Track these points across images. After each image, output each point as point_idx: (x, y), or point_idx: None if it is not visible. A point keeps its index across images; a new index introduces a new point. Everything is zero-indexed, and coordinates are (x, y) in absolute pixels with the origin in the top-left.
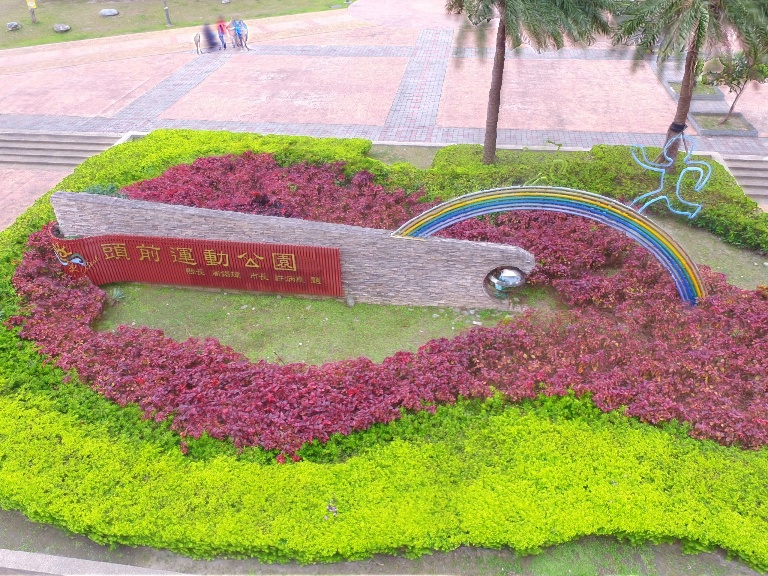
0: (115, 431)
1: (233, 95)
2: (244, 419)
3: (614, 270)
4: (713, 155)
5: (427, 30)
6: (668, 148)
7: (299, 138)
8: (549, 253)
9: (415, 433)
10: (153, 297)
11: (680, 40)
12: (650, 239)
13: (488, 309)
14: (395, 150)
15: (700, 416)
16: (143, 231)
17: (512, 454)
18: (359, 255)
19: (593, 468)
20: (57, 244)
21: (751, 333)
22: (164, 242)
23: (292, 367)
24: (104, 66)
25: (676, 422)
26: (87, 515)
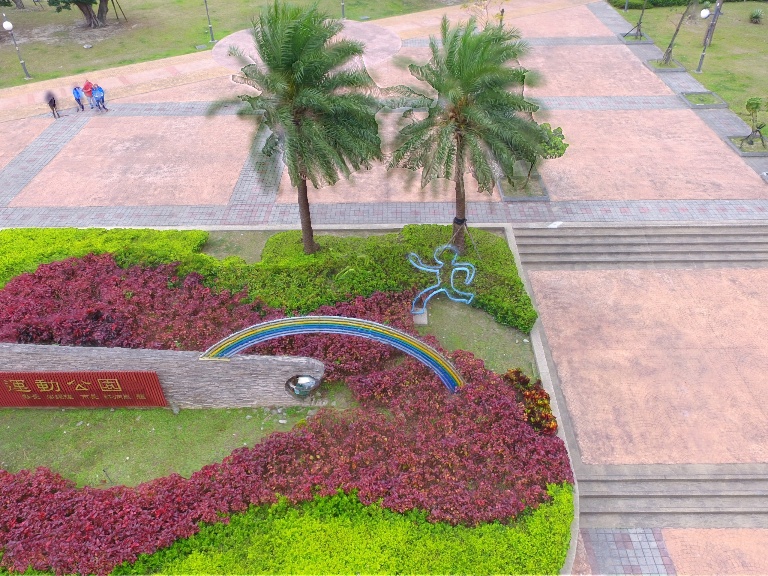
0: None
1: (86, 172)
2: (64, 550)
3: (402, 358)
4: (506, 227)
5: None
6: (455, 237)
7: (141, 232)
8: (345, 351)
9: (211, 544)
10: None
11: (433, 172)
12: (410, 348)
13: (294, 406)
14: (233, 236)
15: (437, 502)
16: None
17: (284, 556)
18: (175, 374)
19: (345, 562)
20: None
21: (492, 417)
22: None
23: (112, 491)
24: None
25: (417, 511)
26: None
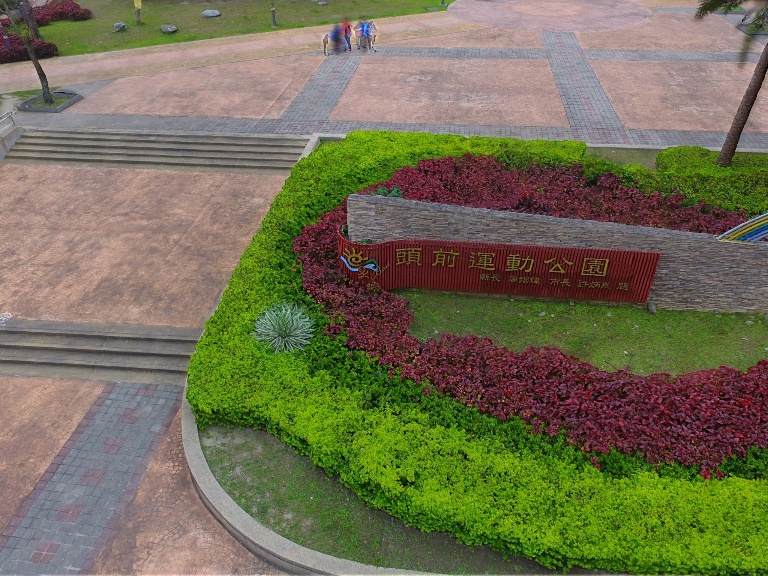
0: (512, 446)
1: (392, 97)
2: (649, 433)
3: None
4: None
5: (546, 32)
6: None
7: (507, 140)
8: None
9: None
10: (437, 304)
11: None
12: None
13: None
14: (604, 152)
15: None
16: (441, 235)
17: None
18: (677, 260)
19: None
20: (353, 249)
21: None
22: (465, 247)
23: (658, 377)
24: (236, 67)
25: None
26: (544, 537)
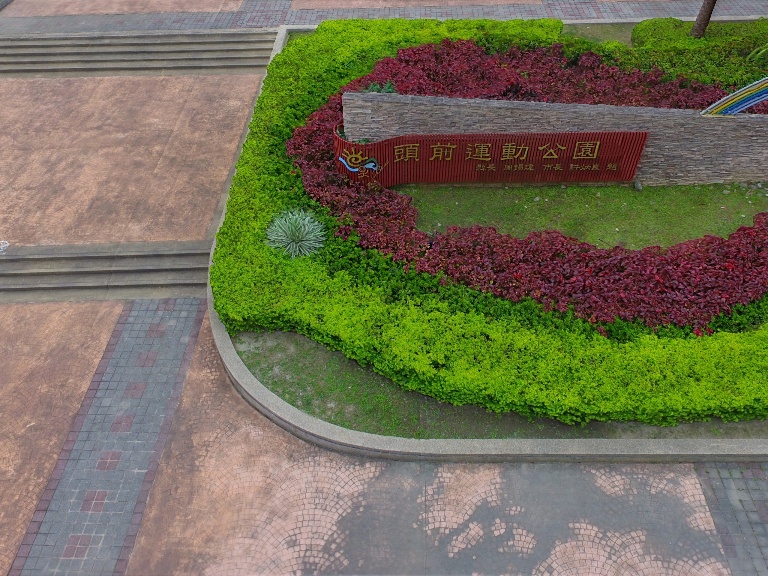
0: (527, 324)
1: None
2: (647, 301)
3: None
4: None
5: None
6: None
7: (483, 22)
8: None
9: None
10: (436, 197)
11: None
12: None
13: None
14: (579, 29)
15: None
16: (438, 129)
17: None
18: (663, 137)
19: None
20: (353, 149)
21: None
22: (462, 139)
23: (651, 250)
24: None
25: None
26: (565, 399)
